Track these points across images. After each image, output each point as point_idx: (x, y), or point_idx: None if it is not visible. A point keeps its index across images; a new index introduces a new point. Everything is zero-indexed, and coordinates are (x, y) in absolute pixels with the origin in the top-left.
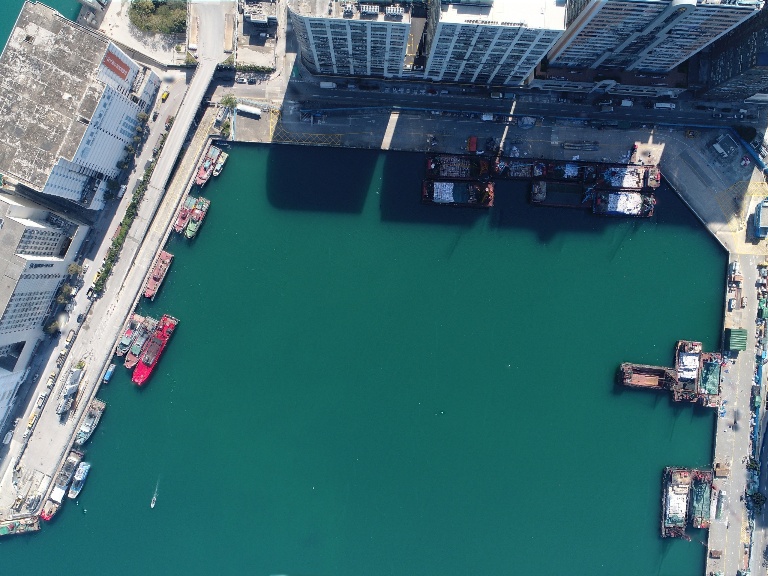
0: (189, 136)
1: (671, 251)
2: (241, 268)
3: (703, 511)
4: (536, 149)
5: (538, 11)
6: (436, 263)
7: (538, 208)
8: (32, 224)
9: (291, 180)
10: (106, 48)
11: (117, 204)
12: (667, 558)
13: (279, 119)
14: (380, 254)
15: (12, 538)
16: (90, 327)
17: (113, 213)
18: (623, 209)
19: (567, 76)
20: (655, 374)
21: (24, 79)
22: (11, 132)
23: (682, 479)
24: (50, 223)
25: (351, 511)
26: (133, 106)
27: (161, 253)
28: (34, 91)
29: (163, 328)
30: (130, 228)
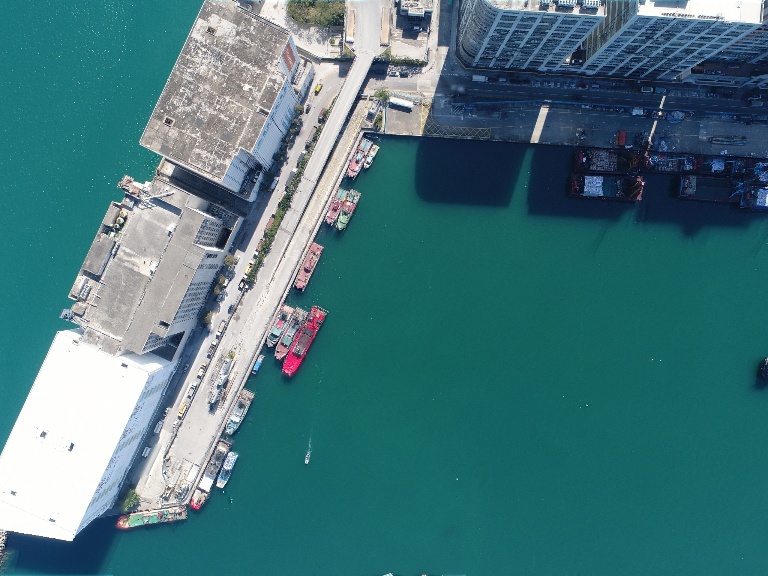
0: (341, 129)
1: None
2: (389, 260)
3: None
4: (684, 143)
5: (734, 4)
6: (582, 256)
7: (684, 202)
8: (205, 214)
9: (438, 173)
10: (287, 40)
11: (269, 196)
12: None
13: (430, 112)
14: (527, 247)
15: (159, 527)
16: (240, 318)
17: (265, 205)
18: None
19: (724, 71)
20: None
21: (205, 70)
22: (192, 123)
23: None
24: (211, 214)
25: (494, 503)
26: (295, 98)
27: (312, 245)
28: (215, 82)
29: (313, 319)
30: (282, 220)
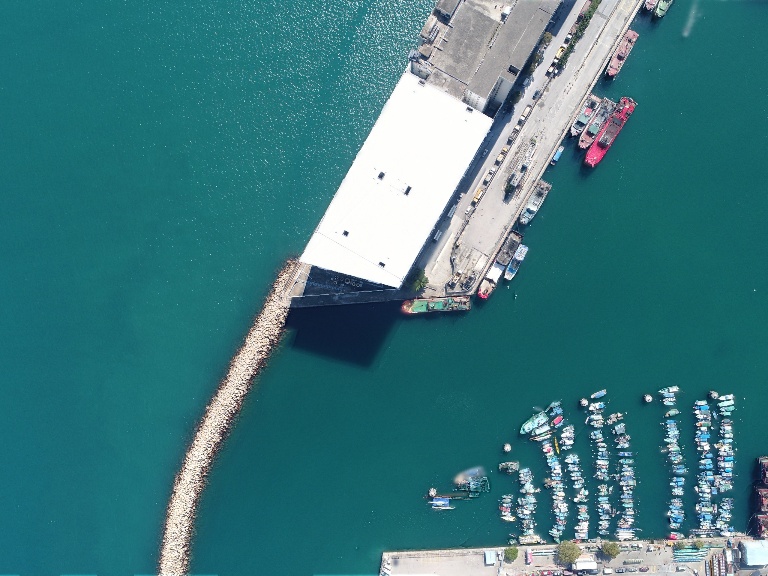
0: None
1: None
2: (705, 55)
3: None
4: None
5: None
6: None
7: None
8: None
9: None
10: None
11: None
12: None
13: None
14: None
15: (439, 317)
16: (545, 105)
17: None
18: None
19: None
20: None
21: None
22: None
23: None
24: None
25: None
26: None
27: (627, 32)
28: None
29: (622, 110)
30: (600, 3)
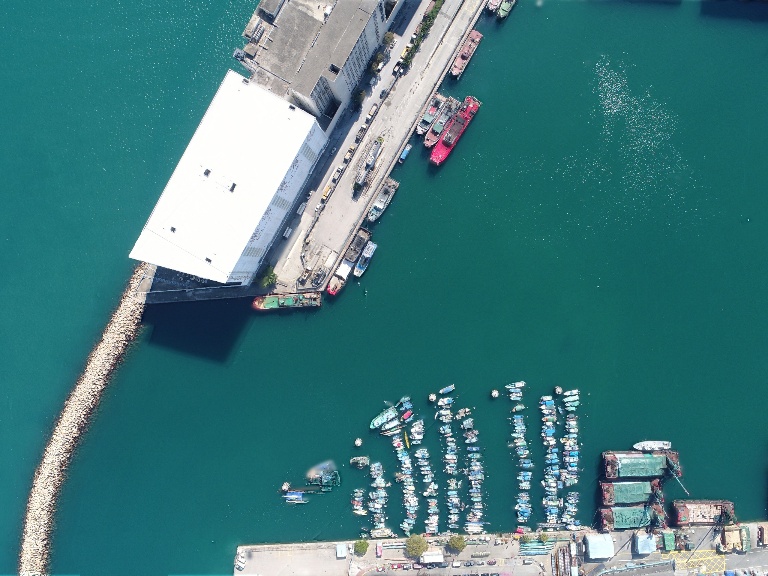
0: None
1: None
2: (548, 55)
3: None
4: None
5: None
6: (756, 62)
7: None
8: None
9: None
10: None
11: None
12: None
13: None
14: (696, 49)
15: (292, 313)
16: (392, 104)
17: None
18: None
19: None
20: None
21: None
22: None
23: None
24: None
25: (638, 317)
26: None
27: (471, 32)
28: None
29: (466, 109)
30: (443, 3)
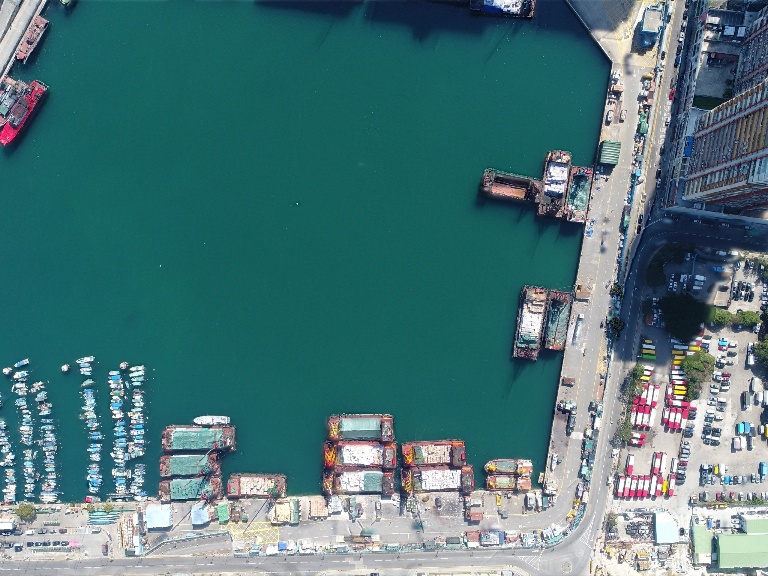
0: None
1: (550, 56)
2: (113, 41)
3: (557, 332)
4: None
5: None
6: (305, 51)
7: (415, 2)
8: None
9: None
10: None
11: None
12: (518, 382)
13: None
14: (250, 37)
15: None
16: None
17: None
18: (500, 5)
19: None
20: (522, 186)
21: None
22: None
23: (537, 295)
24: None
25: (199, 296)
26: None
27: (37, 18)
28: None
29: (32, 92)
30: None
